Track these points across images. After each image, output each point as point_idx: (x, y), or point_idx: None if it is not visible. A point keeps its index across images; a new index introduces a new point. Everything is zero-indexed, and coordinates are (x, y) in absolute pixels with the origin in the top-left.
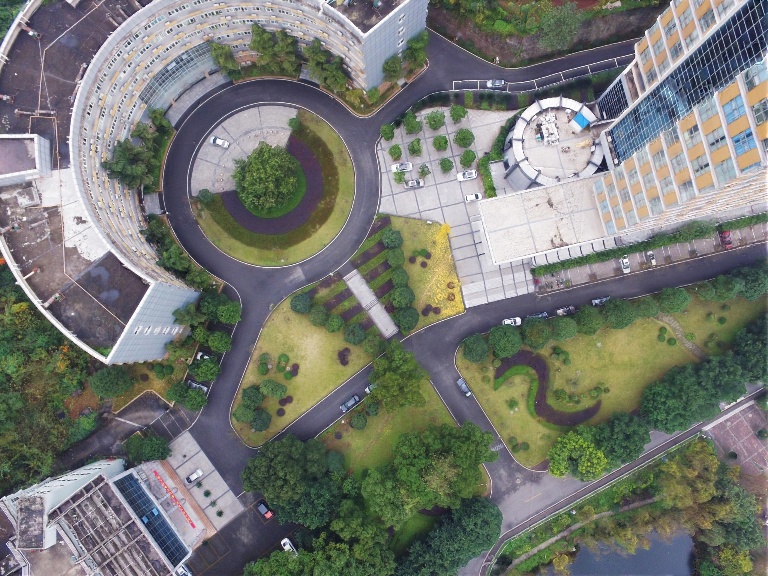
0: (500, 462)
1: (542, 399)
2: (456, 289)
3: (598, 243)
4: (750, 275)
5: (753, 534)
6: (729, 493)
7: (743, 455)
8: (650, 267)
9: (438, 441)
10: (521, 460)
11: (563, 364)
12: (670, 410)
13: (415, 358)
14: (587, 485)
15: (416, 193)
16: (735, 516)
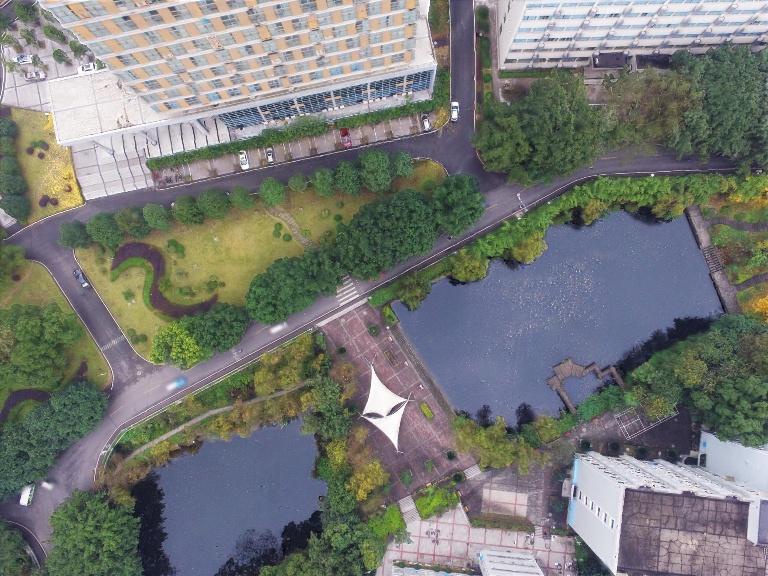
0: (121, 354)
1: (157, 291)
2: (72, 180)
3: (212, 137)
4: (339, 166)
5: (332, 421)
6: (316, 382)
7: (355, 351)
8: (269, 164)
9: (10, 318)
10: (141, 352)
11: (178, 257)
12: (261, 299)
13: (34, 248)
14: (204, 378)
15: (39, 86)
16: (315, 403)
